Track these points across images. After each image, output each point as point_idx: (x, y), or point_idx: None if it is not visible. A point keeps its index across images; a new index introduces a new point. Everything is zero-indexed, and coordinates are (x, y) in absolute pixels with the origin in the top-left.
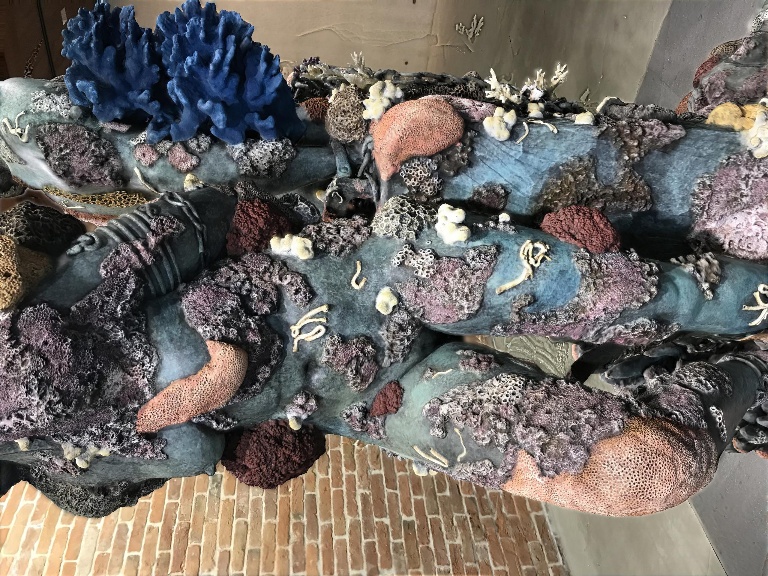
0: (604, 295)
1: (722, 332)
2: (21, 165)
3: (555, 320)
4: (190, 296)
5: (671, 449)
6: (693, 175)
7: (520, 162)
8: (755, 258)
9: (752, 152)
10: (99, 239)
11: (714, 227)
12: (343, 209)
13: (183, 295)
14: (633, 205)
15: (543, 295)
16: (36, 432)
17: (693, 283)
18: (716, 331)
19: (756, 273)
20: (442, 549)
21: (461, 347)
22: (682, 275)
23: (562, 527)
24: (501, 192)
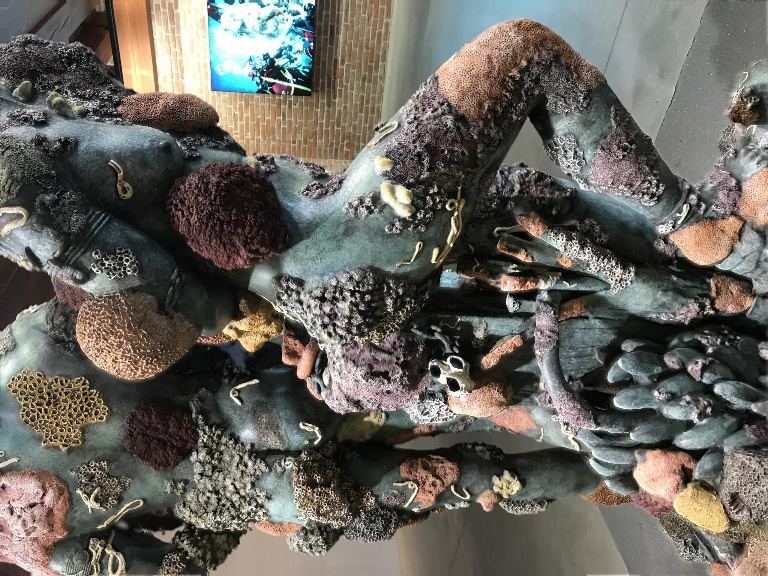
0: None
1: (636, 221)
2: (3, 362)
3: None
4: None
5: None
6: None
7: None
8: None
9: None
10: None
11: None
12: (300, 326)
13: None
14: None
15: None
16: (54, 63)
17: None
18: (628, 218)
19: None
20: None
21: None
22: None
23: None
24: None
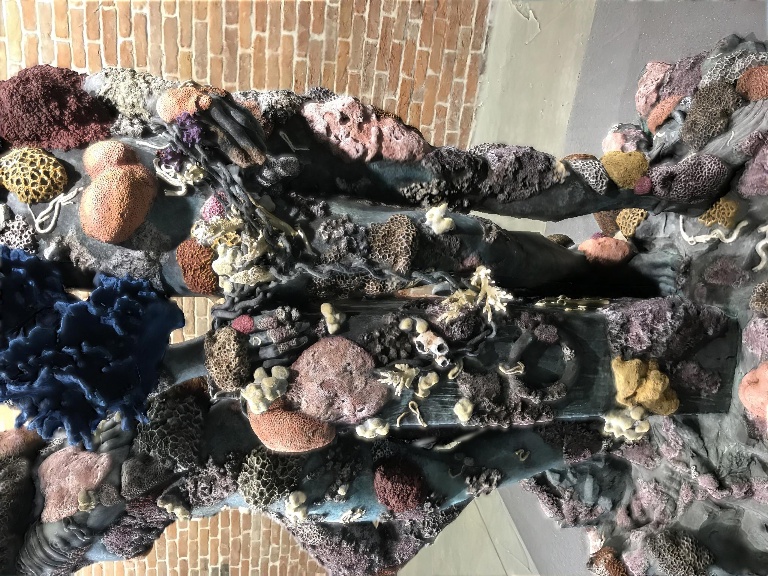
0: None
1: None
2: None
3: None
4: (106, 539)
5: None
6: None
7: None
8: None
9: None
10: (36, 574)
11: None
12: None
13: (101, 538)
14: None
15: None
16: None
17: None
18: None
19: None
20: (375, 21)
21: None
22: (461, 498)
23: (498, 23)
24: None
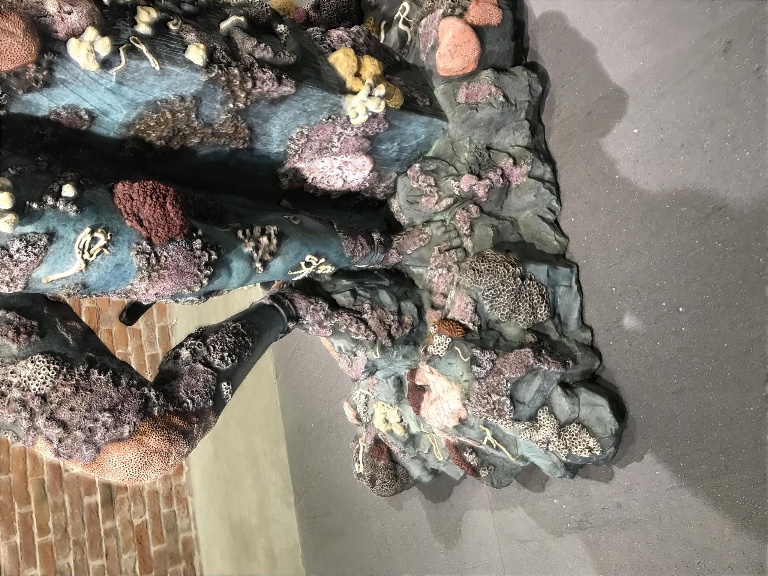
0: (158, 284)
1: None
2: None
3: (107, 296)
4: None
5: (169, 445)
6: (294, 124)
7: (111, 91)
8: (331, 190)
9: (350, 118)
10: None
11: (302, 167)
12: None
13: None
14: (231, 142)
15: (95, 284)
16: None
17: (247, 264)
18: None
19: (308, 245)
20: None
21: (6, 302)
22: (240, 257)
23: None
24: (84, 117)
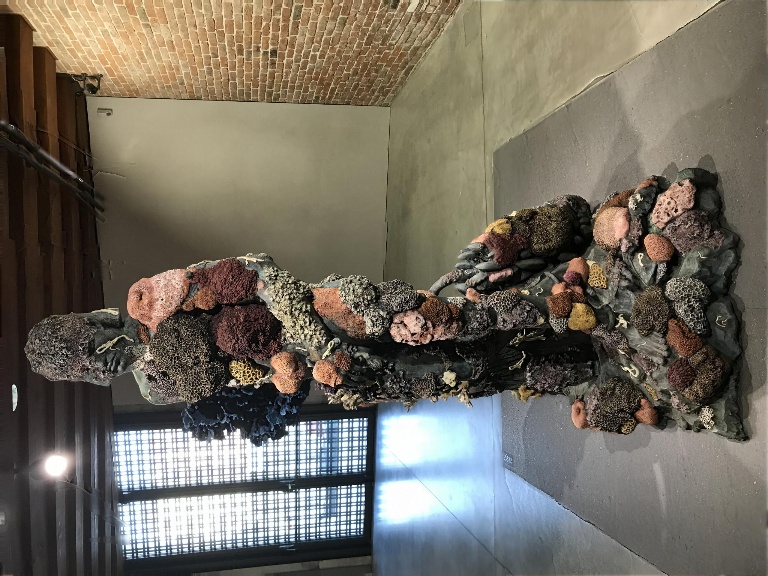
0: None
1: None
2: None
3: None
4: None
5: None
6: None
7: None
8: None
9: None
10: None
11: None
12: None
13: None
14: None
15: None
16: None
17: None
18: None
19: None
20: None
21: None
22: None
23: None
24: None
